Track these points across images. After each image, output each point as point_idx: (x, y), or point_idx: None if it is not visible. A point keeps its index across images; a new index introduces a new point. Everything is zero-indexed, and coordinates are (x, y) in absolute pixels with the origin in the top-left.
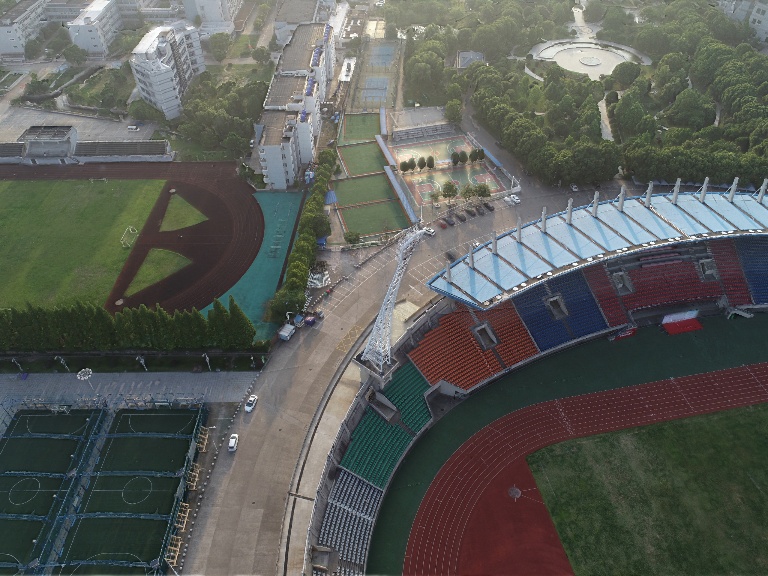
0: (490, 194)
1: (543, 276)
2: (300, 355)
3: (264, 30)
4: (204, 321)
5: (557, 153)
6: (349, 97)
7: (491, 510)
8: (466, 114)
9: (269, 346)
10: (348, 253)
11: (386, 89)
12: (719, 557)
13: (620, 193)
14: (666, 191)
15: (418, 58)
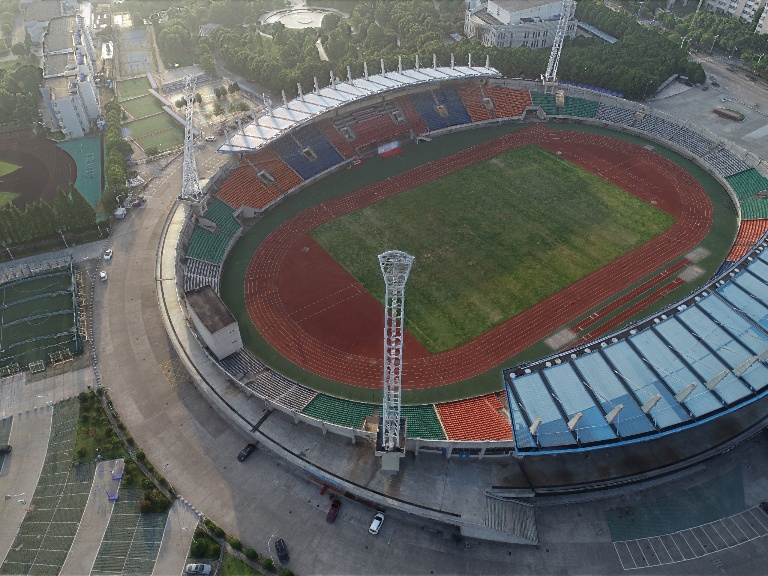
0: (250, 109)
1: (291, 127)
2: (136, 223)
3: (14, 34)
4: (52, 210)
5: (290, 73)
6: (116, 70)
7: (292, 260)
8: (218, 67)
9: (109, 222)
10: (152, 163)
11: (146, 60)
12: (424, 244)
13: (331, 77)
14: None
15: (167, 31)
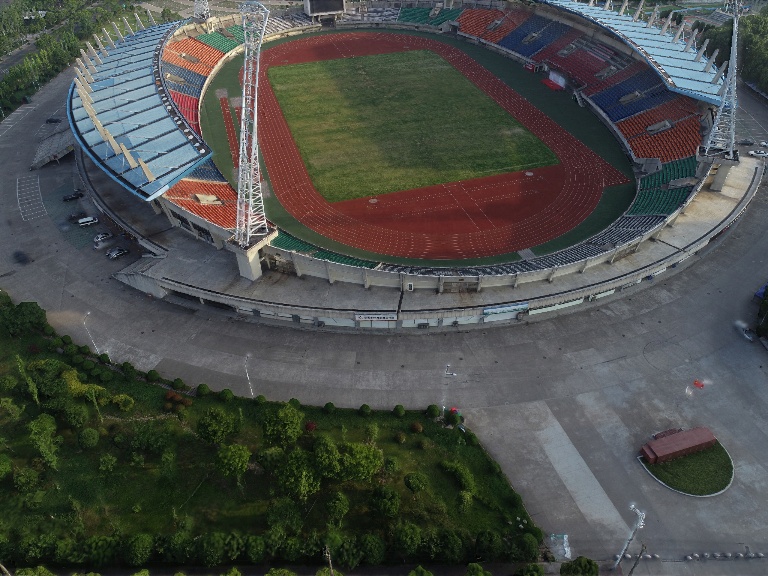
0: None
1: None
2: None
3: None
4: None
5: None
6: None
7: None
8: None
9: None
10: None
11: None
12: None
13: None
14: (748, 94)
15: None
